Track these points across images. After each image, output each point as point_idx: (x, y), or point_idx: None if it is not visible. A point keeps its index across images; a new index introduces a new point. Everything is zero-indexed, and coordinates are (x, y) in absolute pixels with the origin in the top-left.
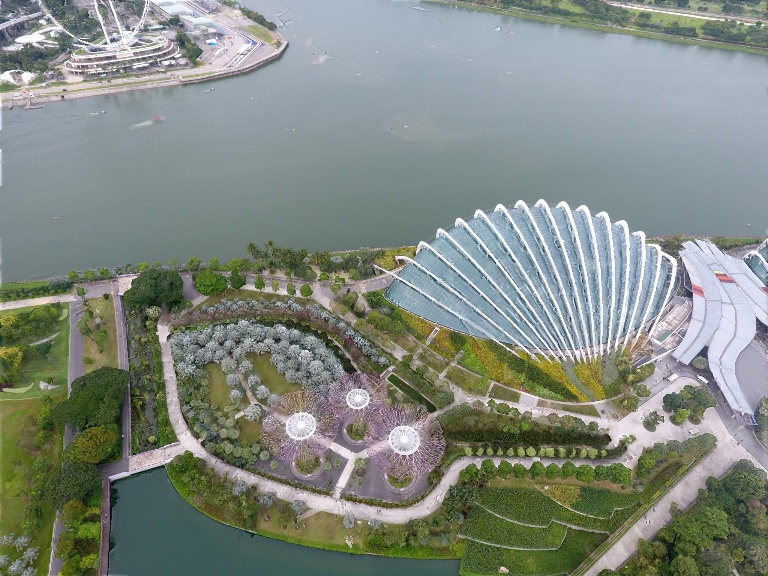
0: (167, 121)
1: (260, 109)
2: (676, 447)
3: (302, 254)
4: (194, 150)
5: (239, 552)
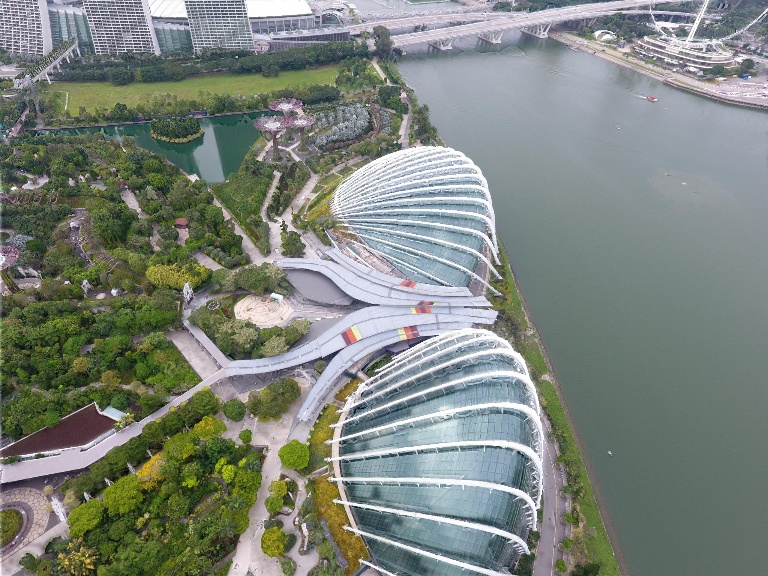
0: (584, 82)
1: (648, 114)
2: None
3: (426, 124)
4: (553, 97)
5: (259, 134)
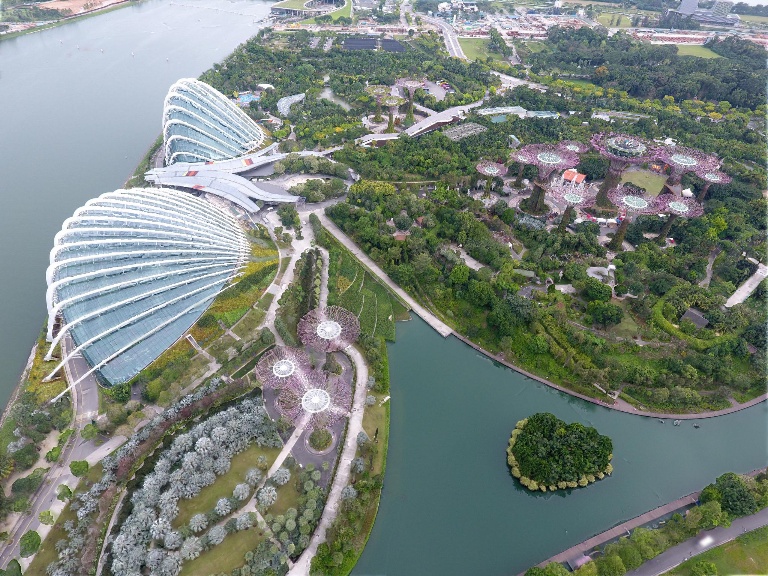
0: None
1: None
2: (319, 228)
3: None
4: None
5: None
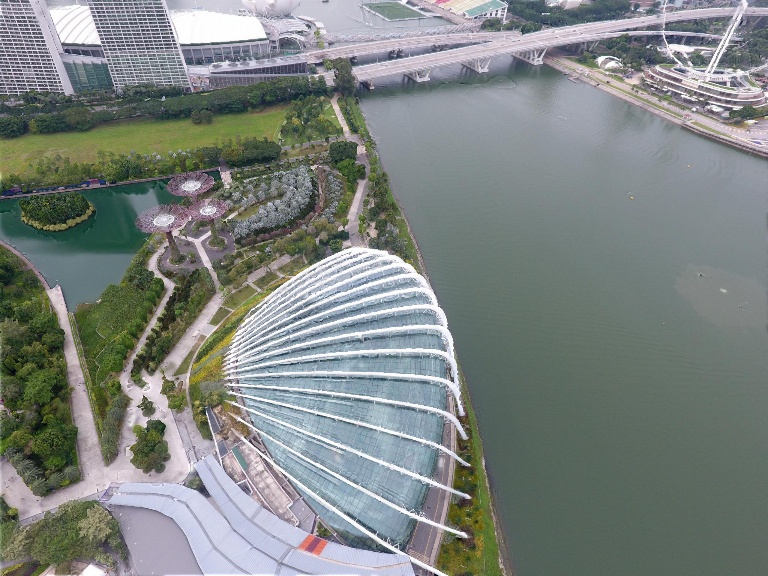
0: (586, 128)
1: (667, 174)
2: None
3: (383, 202)
4: (549, 149)
5: None
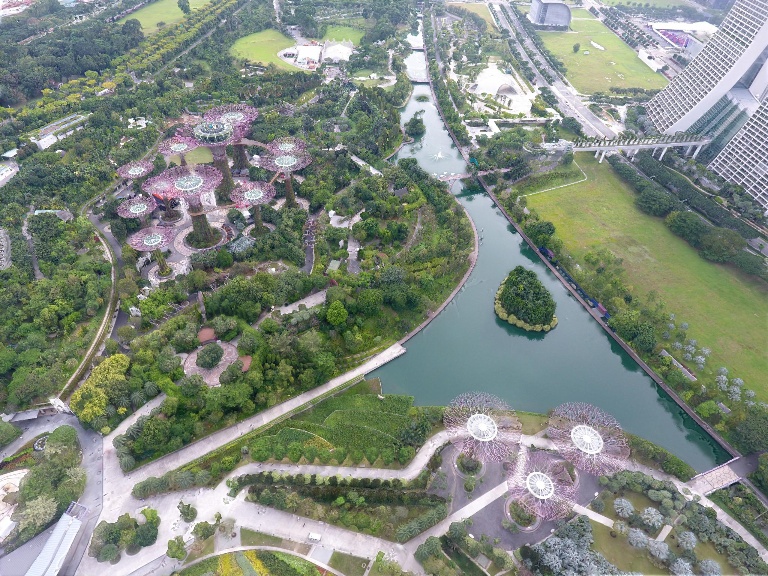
0: None
1: None
2: (188, 474)
3: None
4: None
5: None
